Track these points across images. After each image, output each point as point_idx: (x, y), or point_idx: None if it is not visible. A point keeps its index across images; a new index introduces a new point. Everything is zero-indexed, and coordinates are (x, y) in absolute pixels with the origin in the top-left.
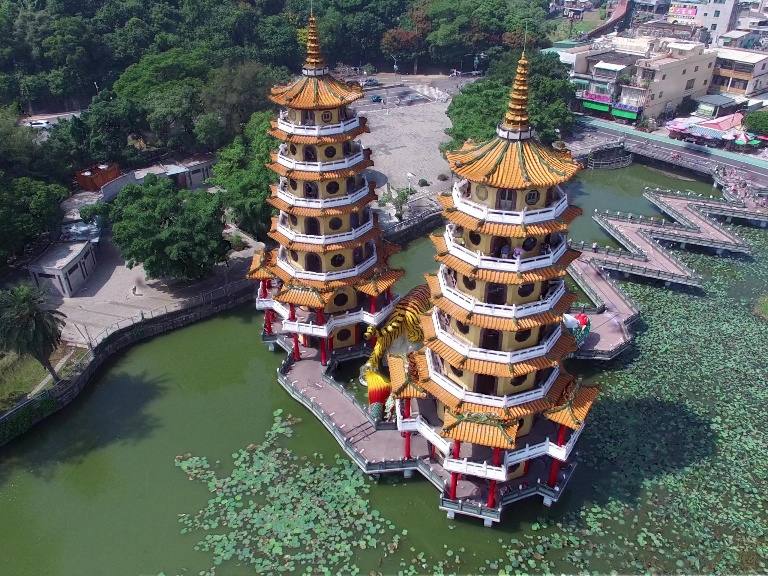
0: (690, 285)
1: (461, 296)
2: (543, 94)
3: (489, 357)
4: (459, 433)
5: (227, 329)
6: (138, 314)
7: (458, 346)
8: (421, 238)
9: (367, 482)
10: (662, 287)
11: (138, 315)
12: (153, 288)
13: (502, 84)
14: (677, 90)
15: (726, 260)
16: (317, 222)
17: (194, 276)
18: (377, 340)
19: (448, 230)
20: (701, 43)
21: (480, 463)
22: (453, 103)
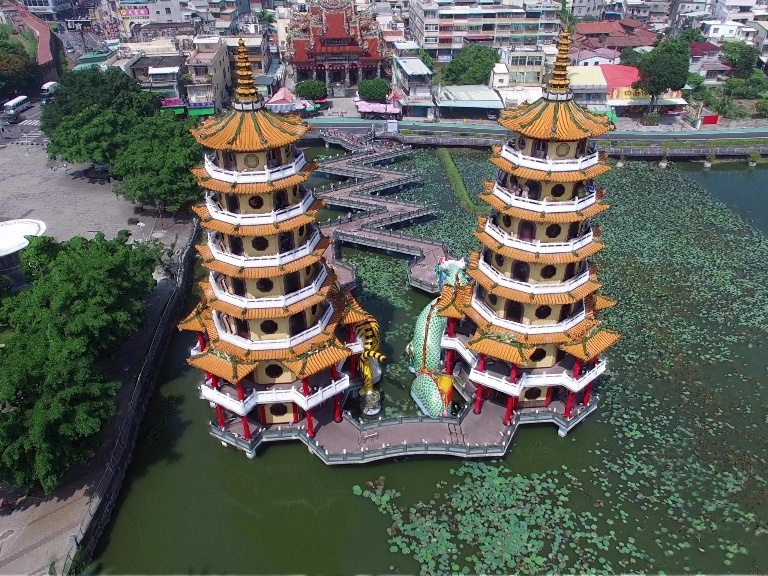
0: (431, 213)
1: (558, 244)
2: (140, 109)
3: (579, 283)
4: (592, 351)
5: (162, 482)
6: (70, 544)
7: (558, 288)
8: (196, 283)
9: (497, 466)
10: (413, 224)
11: (71, 545)
12: (11, 514)
13: (99, 109)
14: (221, 80)
15: (412, 191)
16: (297, 274)
17: (90, 448)
18: (365, 365)
19: (519, 198)
20: (219, 35)
21: (593, 368)
22: (56, 144)
